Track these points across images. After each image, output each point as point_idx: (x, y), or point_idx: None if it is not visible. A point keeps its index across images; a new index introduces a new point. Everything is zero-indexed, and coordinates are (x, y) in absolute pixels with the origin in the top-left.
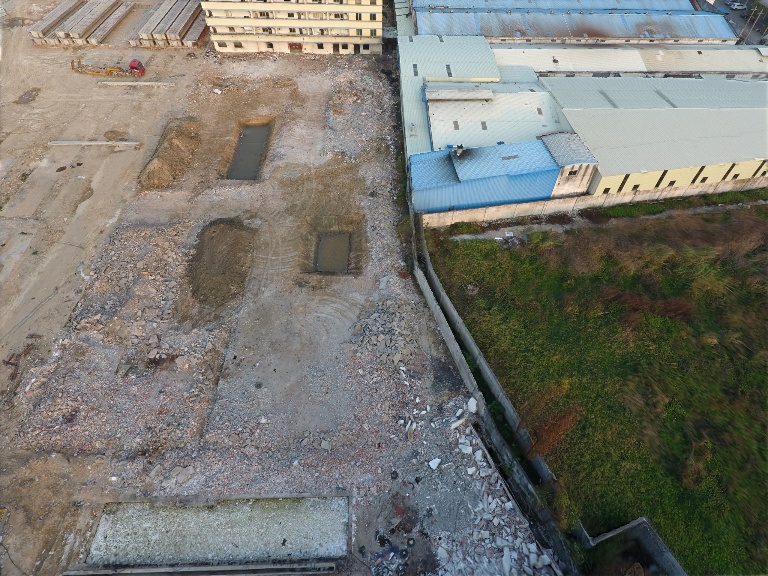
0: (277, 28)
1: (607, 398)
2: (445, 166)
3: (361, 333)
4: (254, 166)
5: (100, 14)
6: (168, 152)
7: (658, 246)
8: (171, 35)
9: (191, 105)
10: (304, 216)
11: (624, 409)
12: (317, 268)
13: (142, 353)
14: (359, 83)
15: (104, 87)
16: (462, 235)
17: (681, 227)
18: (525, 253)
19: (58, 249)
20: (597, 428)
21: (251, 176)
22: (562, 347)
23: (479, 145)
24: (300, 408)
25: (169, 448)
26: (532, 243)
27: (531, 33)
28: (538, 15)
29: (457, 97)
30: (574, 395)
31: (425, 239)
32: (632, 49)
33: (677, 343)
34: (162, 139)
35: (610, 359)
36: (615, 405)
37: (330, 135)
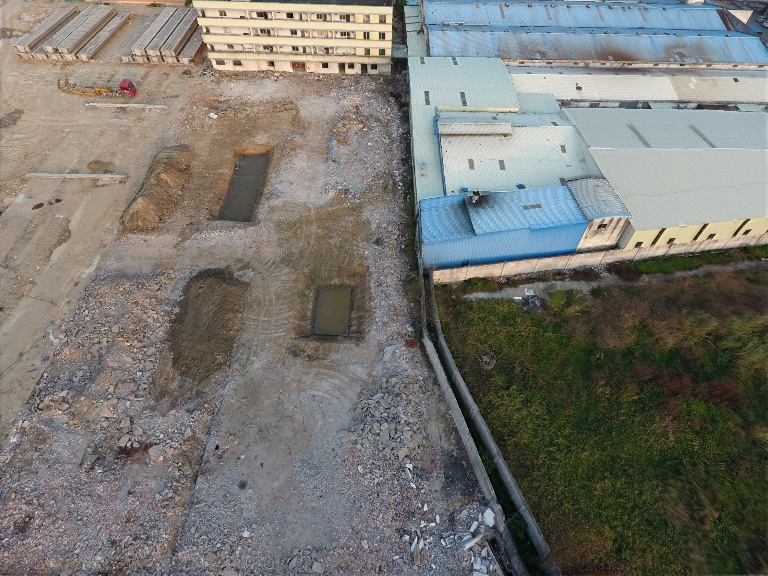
0: (279, 46)
1: (646, 509)
2: (459, 215)
3: (362, 418)
4: (249, 204)
5: (92, 27)
6: (155, 189)
7: (699, 315)
8: (166, 51)
9: (184, 131)
10: (301, 267)
11: (666, 524)
12: (314, 330)
13: (112, 439)
14: (366, 108)
15: (91, 109)
16: (477, 293)
17: (723, 290)
18: (548, 319)
19: (27, 305)
20: (635, 550)
21: (245, 216)
22: (592, 440)
23: (496, 188)
24: (289, 516)
25: (135, 568)
26: (556, 307)
27: (552, 55)
28: (560, 35)
29: (473, 131)
30: (607, 504)
31: (436, 299)
32: (662, 75)
33: (724, 437)
34: (150, 172)
35: (647, 456)
36: (655, 519)
37: (333, 169)
